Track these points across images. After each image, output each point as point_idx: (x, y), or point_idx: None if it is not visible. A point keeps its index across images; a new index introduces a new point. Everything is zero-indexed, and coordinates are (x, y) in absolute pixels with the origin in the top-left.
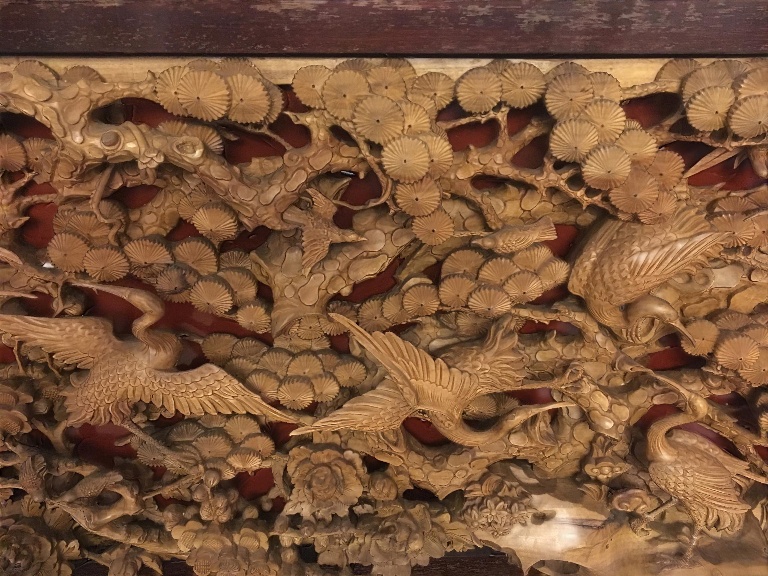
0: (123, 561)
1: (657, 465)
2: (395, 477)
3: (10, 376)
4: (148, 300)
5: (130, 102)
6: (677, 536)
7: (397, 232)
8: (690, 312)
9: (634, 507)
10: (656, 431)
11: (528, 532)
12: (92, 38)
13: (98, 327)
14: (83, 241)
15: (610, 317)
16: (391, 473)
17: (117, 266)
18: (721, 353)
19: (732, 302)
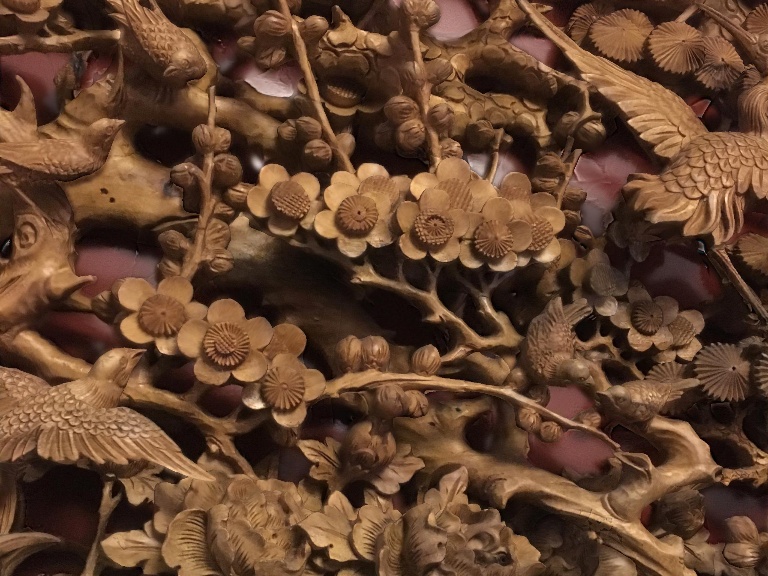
0: None
1: None
2: None
3: None
4: None
5: None
6: None
7: None
8: None
9: None
10: None
11: None
12: None
13: None
14: (637, 28)
15: None
16: None
17: (696, 48)
18: None
19: None
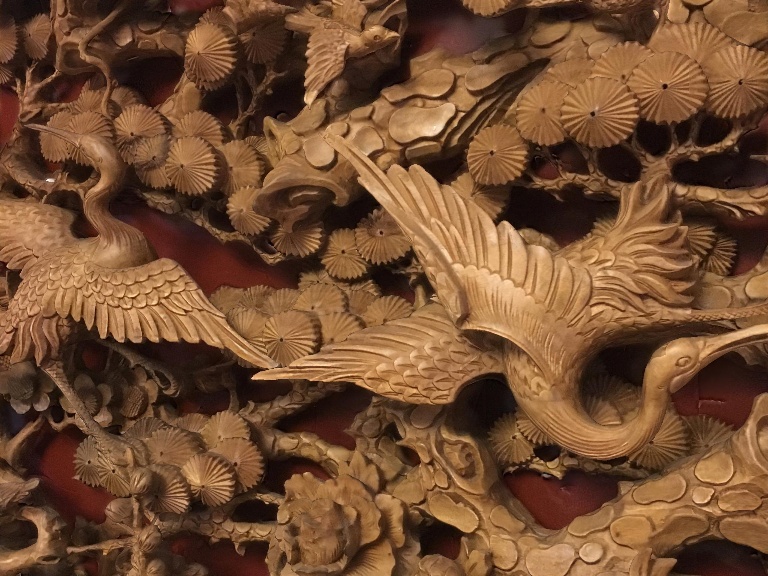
0: None
1: None
2: (466, 562)
3: None
4: (100, 142)
5: None
6: None
7: (473, 70)
8: None
9: None
10: None
11: None
12: None
13: (55, 215)
14: None
15: None
16: (462, 558)
17: None
18: None
19: None
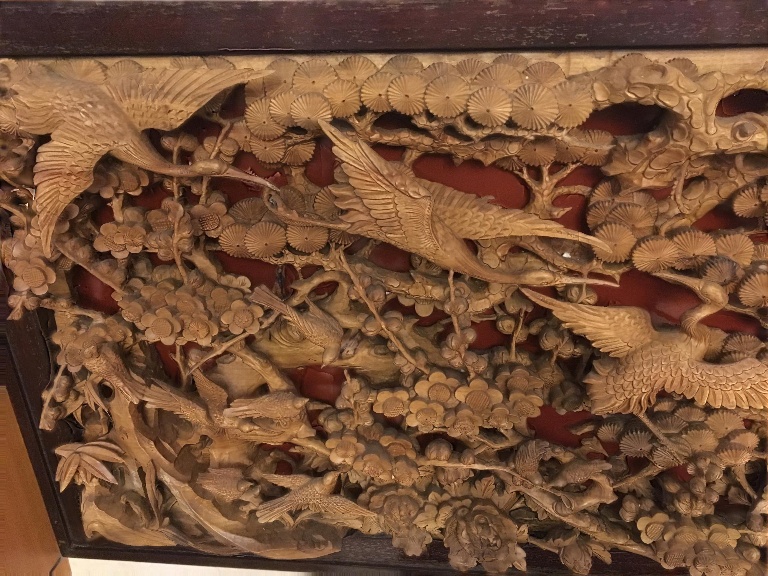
0: (579, 548)
1: None
2: None
3: (505, 362)
4: (723, 291)
5: (745, 93)
6: None
7: None
8: None
9: None
10: None
11: None
12: (712, 30)
13: (641, 317)
14: (631, 232)
15: None
16: None
17: (669, 257)
18: None
19: None
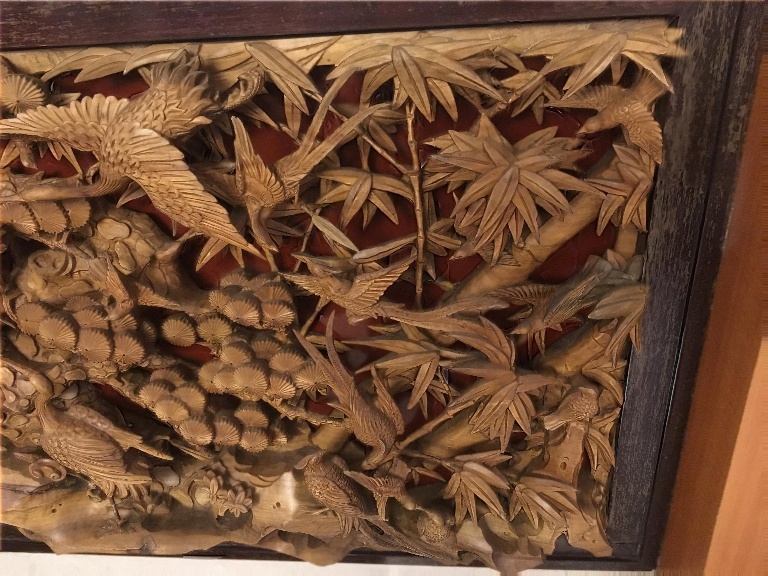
0: None
1: (41, 437)
2: None
3: None
4: None
5: None
6: (133, 504)
7: None
8: (67, 294)
9: (49, 475)
10: (35, 405)
11: None
12: None
13: None
14: None
15: None
16: None
17: None
18: (41, 334)
19: (99, 284)
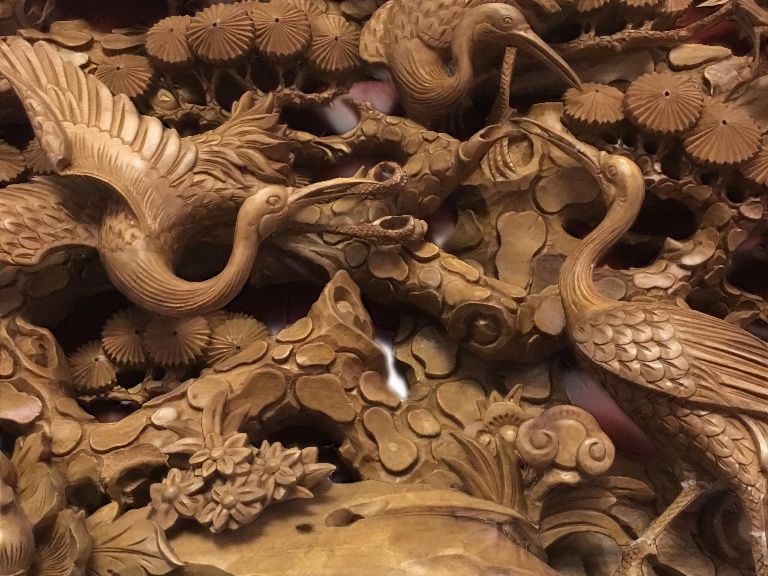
0: None
1: (587, 319)
2: (18, 455)
3: None
4: None
5: None
6: None
7: (111, 36)
8: None
9: (572, 453)
10: (569, 266)
11: (314, 541)
12: None
13: None
14: None
15: (432, 80)
16: (14, 458)
17: None
18: (632, 99)
19: None
